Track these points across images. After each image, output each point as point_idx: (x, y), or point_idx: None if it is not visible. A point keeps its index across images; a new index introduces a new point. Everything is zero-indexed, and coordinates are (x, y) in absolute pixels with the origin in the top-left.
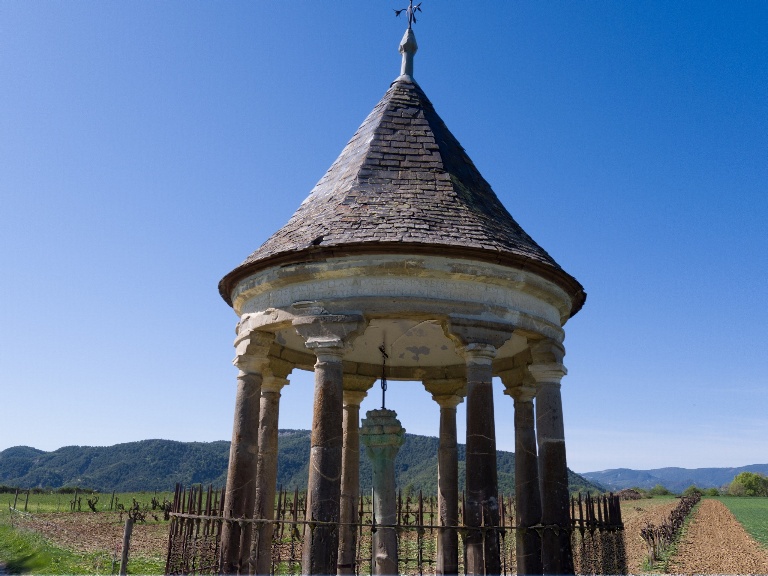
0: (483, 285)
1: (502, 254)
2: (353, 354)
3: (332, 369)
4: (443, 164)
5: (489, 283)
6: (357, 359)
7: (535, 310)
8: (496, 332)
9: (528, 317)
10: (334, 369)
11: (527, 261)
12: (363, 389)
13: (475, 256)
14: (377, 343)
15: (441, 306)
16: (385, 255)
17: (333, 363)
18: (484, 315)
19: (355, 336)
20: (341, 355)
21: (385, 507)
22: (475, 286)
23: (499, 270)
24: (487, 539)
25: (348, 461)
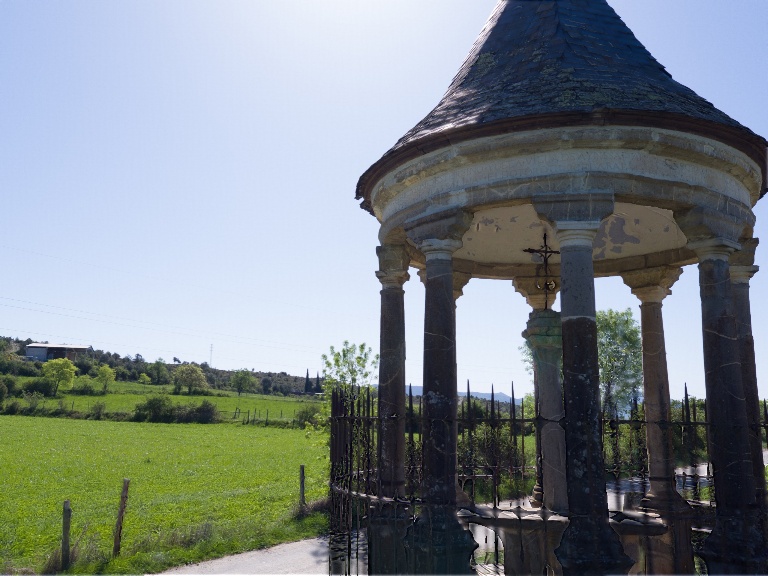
0: (432, 178)
1: (419, 144)
2: (639, 247)
3: (383, 295)
4: (483, 46)
5: (436, 174)
6: (644, 251)
7: (501, 174)
8: (438, 223)
9: (481, 189)
10: (384, 295)
11: (448, 134)
12: (654, 283)
13: (404, 158)
14: (661, 226)
15: (400, 217)
16: (373, 190)
17: (383, 290)
18: (429, 210)
19: (395, 262)
20: (391, 281)
21: (541, 410)
22: (426, 183)
23: (430, 158)
24: (425, 432)
25: (645, 365)
